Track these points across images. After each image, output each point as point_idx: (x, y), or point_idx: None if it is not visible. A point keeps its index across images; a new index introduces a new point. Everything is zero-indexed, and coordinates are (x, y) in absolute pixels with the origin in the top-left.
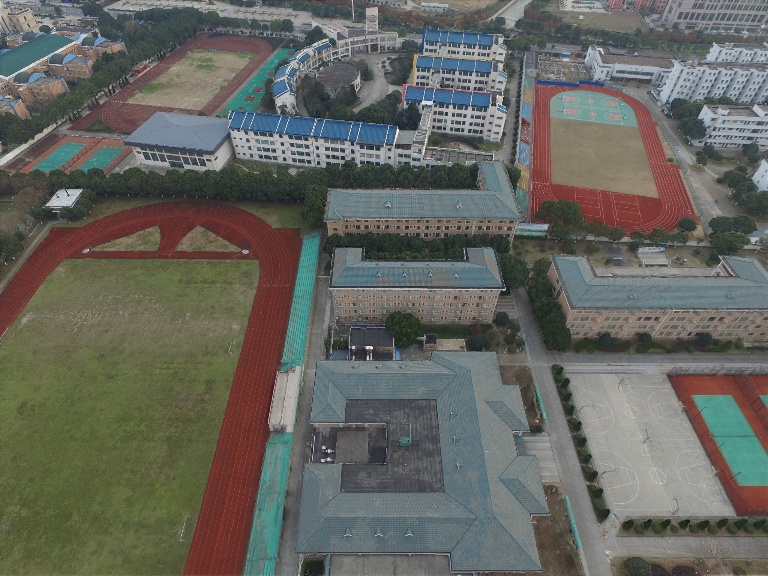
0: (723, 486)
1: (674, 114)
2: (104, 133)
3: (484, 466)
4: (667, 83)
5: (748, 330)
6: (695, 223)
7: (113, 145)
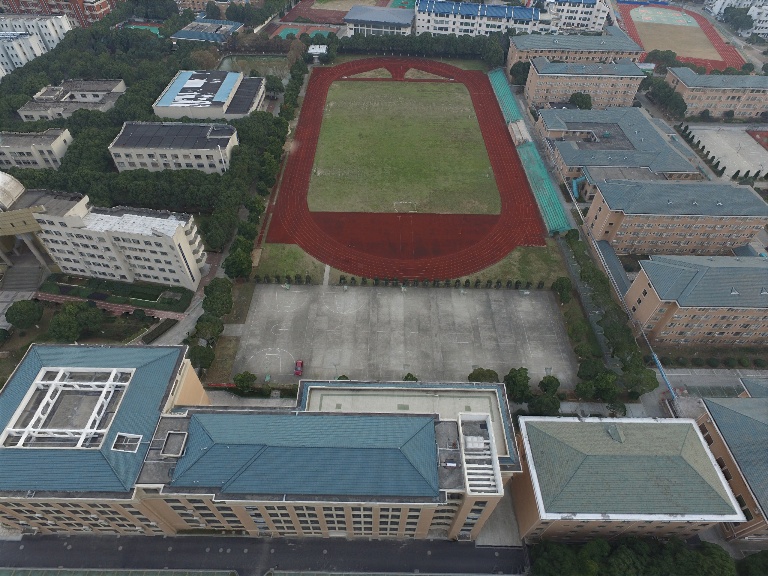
0: None
1: (726, 19)
2: (309, 23)
3: (659, 135)
4: None
5: None
6: (753, 65)
7: (321, 29)
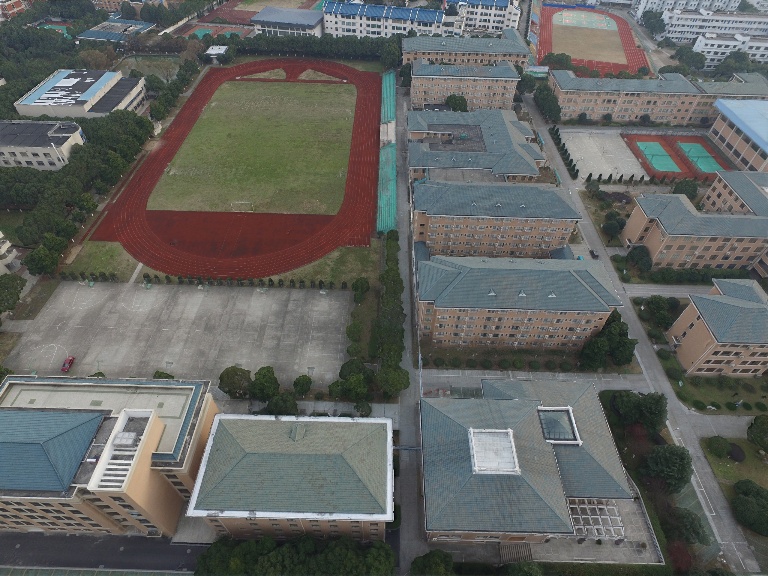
0: (645, 171)
1: (645, 23)
2: (225, 24)
3: (509, 138)
4: (642, 2)
5: (673, 113)
6: None
7: (234, 30)
